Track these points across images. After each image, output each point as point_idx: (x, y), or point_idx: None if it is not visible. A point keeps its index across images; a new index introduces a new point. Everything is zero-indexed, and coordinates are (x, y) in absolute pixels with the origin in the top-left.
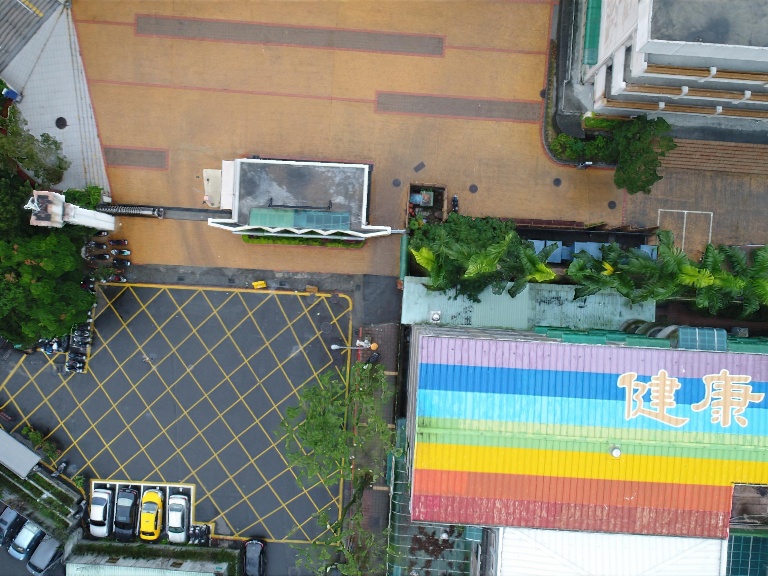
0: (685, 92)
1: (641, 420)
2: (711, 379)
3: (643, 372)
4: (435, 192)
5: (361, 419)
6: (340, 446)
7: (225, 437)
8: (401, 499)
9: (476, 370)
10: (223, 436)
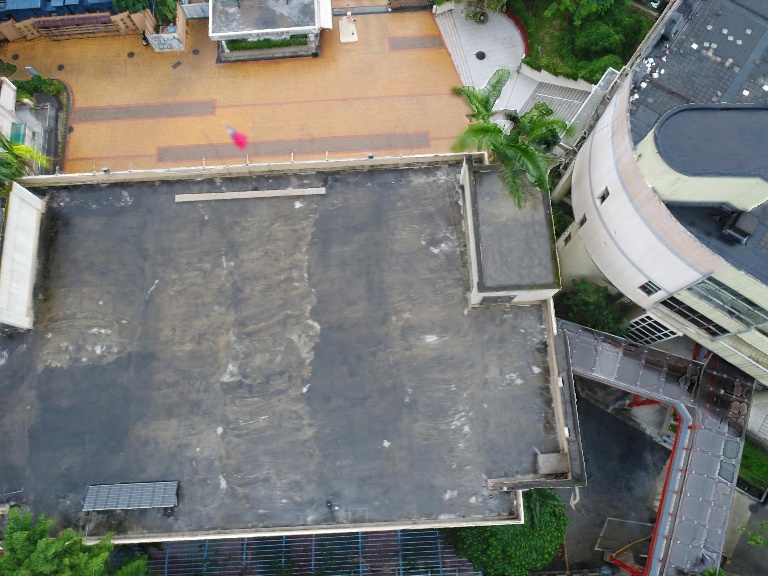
0: None
1: None
2: None
3: None
4: None
5: None
6: None
7: None
8: None
9: None
10: None
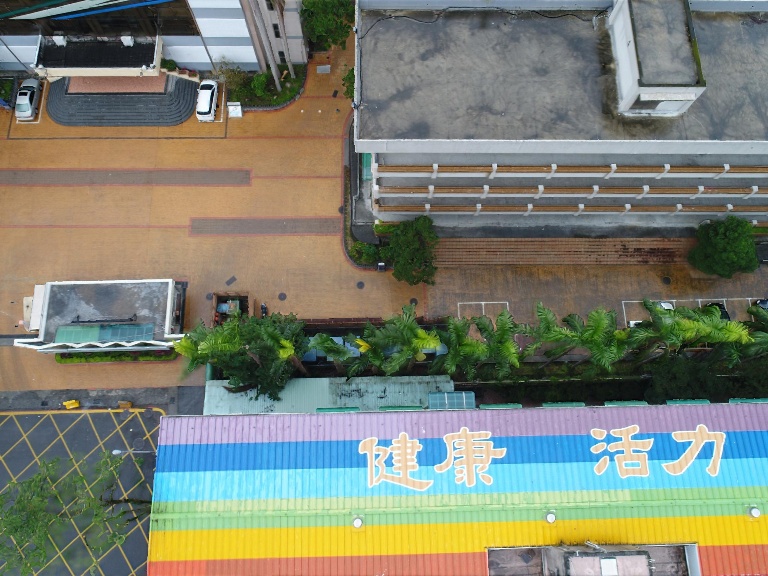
0: (432, 190)
1: (384, 486)
2: (452, 438)
3: (384, 436)
4: (245, 302)
5: None
6: (37, 529)
7: None
8: None
9: (215, 448)
10: None
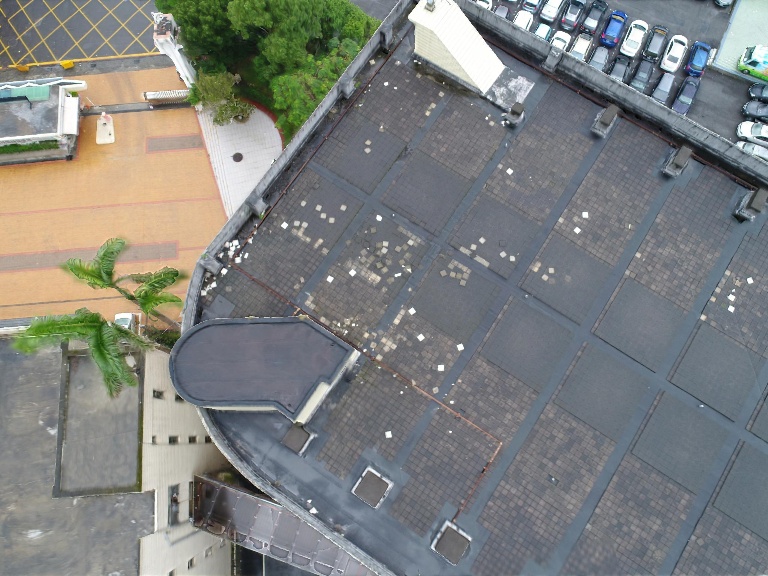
0: None
1: None
2: None
3: None
4: None
5: None
6: None
7: None
8: None
9: None
10: None
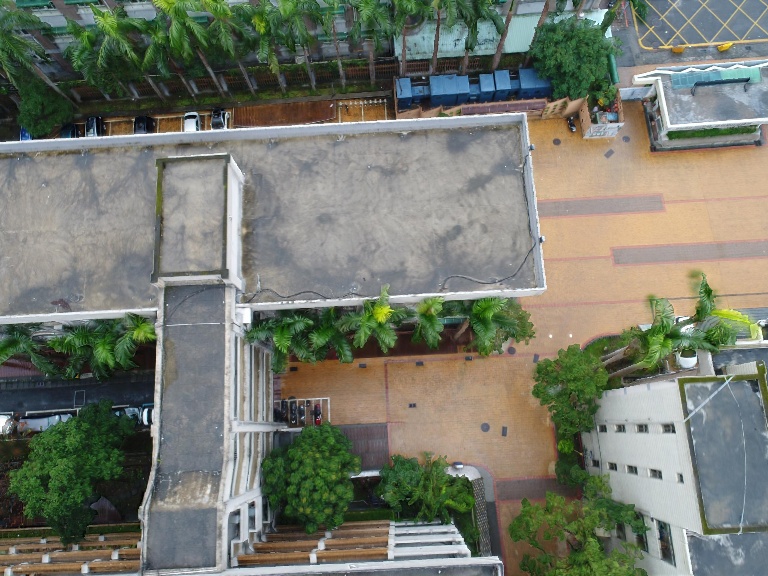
0: None
1: None
2: None
3: None
4: None
5: None
6: None
7: None
8: None
9: None
10: None
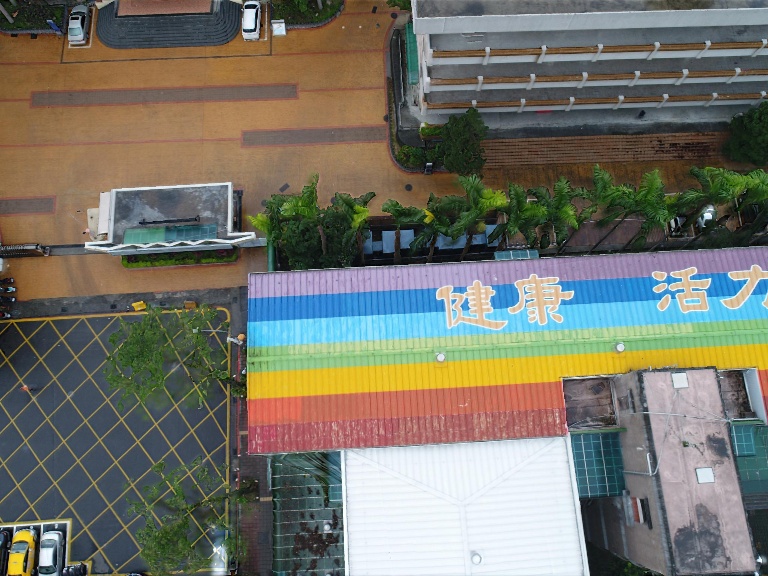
0: (481, 80)
1: (462, 327)
2: (522, 283)
3: (458, 284)
4: None
5: (244, 427)
6: (153, 356)
7: (104, 463)
8: (280, 495)
9: (302, 299)
10: (102, 462)
